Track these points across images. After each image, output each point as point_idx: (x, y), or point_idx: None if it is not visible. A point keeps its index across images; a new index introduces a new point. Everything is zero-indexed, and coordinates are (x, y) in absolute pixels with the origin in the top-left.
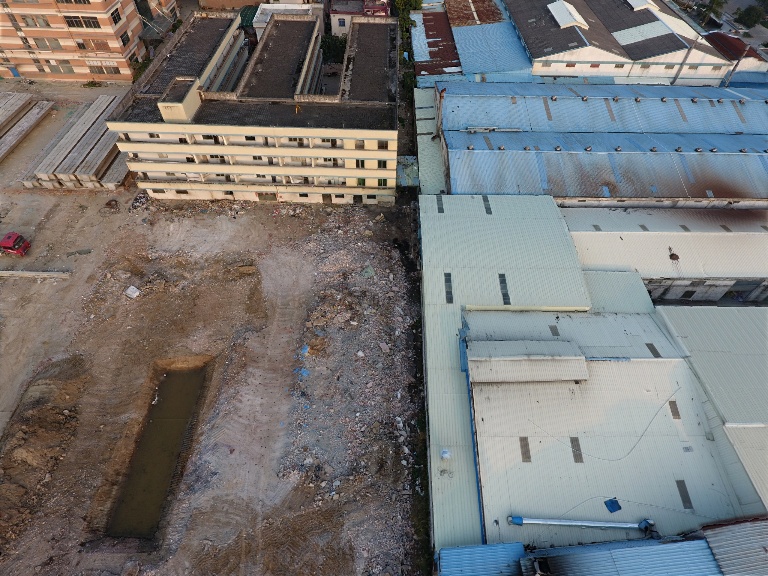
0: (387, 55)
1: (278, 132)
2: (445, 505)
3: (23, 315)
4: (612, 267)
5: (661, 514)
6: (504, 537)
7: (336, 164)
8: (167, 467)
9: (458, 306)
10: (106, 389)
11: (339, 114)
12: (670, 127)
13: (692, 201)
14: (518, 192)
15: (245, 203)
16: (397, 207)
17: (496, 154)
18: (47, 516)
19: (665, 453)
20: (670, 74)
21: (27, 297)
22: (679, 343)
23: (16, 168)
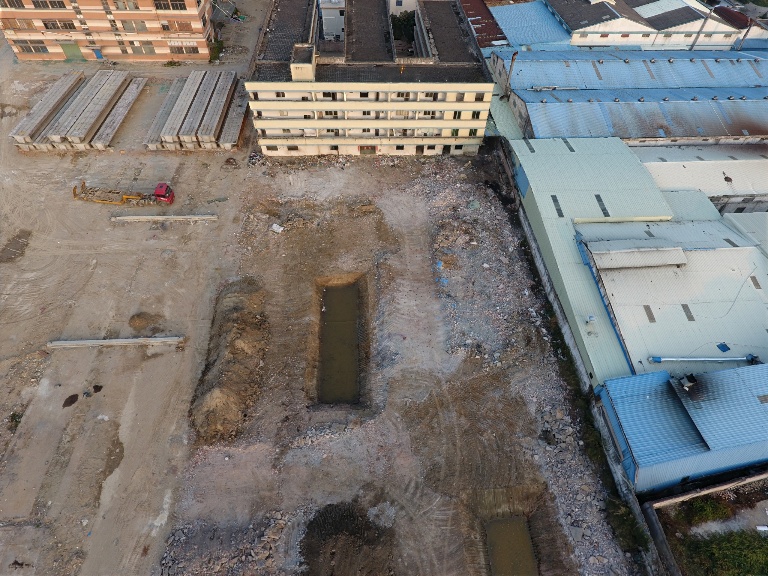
0: (458, 26)
1: (393, 87)
2: (598, 354)
3: (189, 249)
4: (680, 189)
5: (760, 351)
6: (648, 371)
7: (433, 117)
8: (351, 355)
9: (569, 219)
10: (283, 300)
11: (437, 73)
12: (701, 83)
13: (731, 139)
14: (590, 135)
15: (348, 157)
16: (480, 156)
17: (566, 106)
18: (272, 389)
19: (754, 312)
20: (688, 42)
21: (187, 236)
22: (749, 236)
23: (133, 135)
